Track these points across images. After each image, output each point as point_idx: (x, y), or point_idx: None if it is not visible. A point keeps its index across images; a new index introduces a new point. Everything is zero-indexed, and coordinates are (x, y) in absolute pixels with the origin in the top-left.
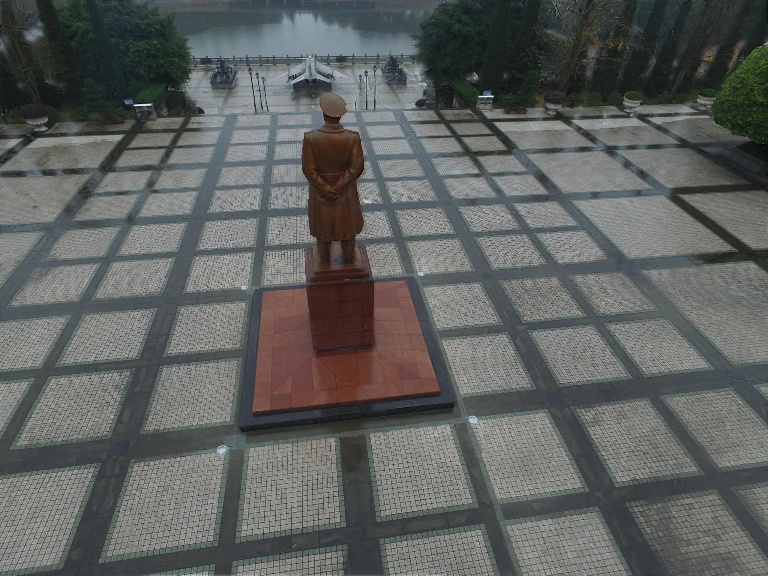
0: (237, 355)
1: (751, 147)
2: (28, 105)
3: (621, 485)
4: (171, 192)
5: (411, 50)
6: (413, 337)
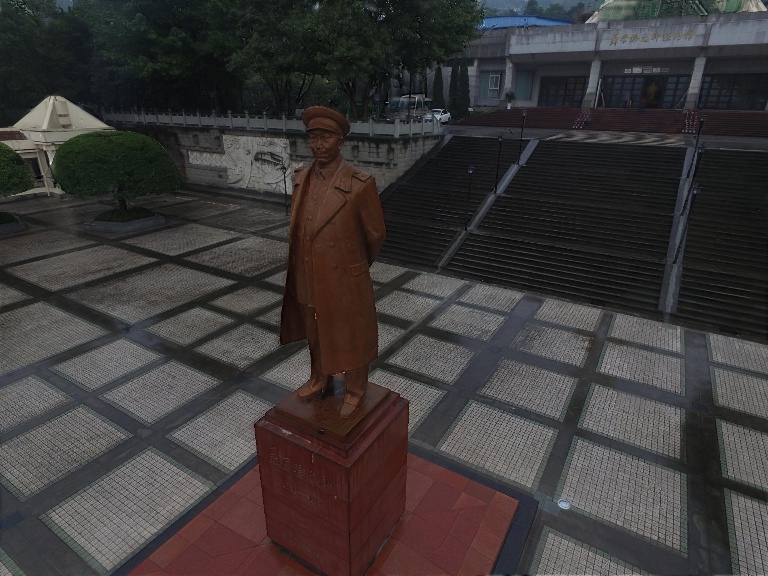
0: None
1: None
2: None
3: None
4: None
5: None
6: None
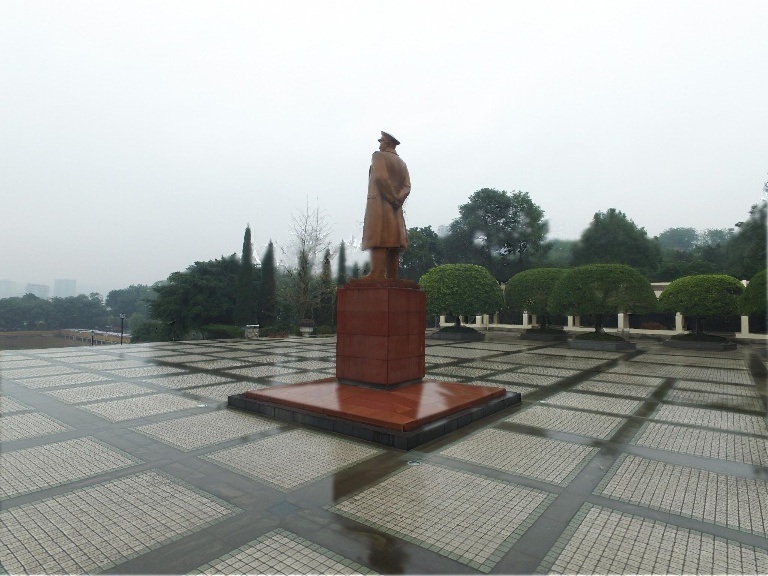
0: (291, 428)
1: (447, 329)
2: None
3: (648, 397)
4: None
5: (146, 310)
6: None
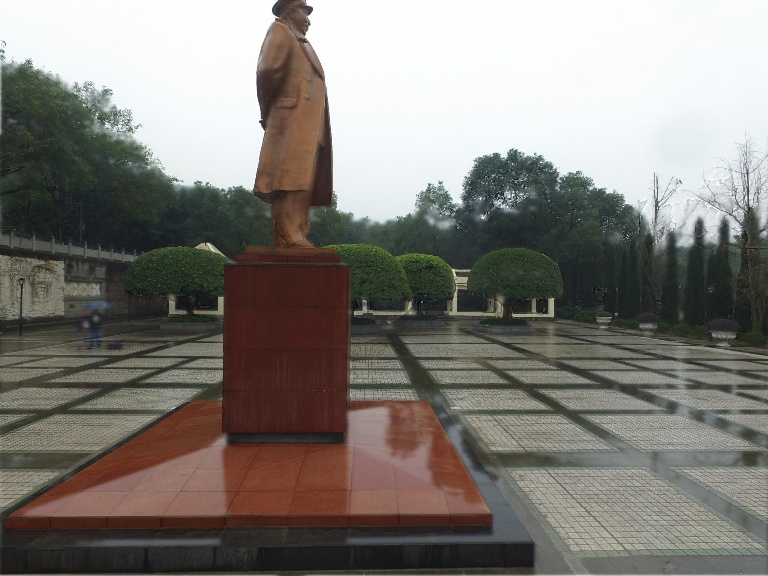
0: None
1: None
2: (721, 319)
3: None
4: (669, 376)
5: None
6: (224, 496)
